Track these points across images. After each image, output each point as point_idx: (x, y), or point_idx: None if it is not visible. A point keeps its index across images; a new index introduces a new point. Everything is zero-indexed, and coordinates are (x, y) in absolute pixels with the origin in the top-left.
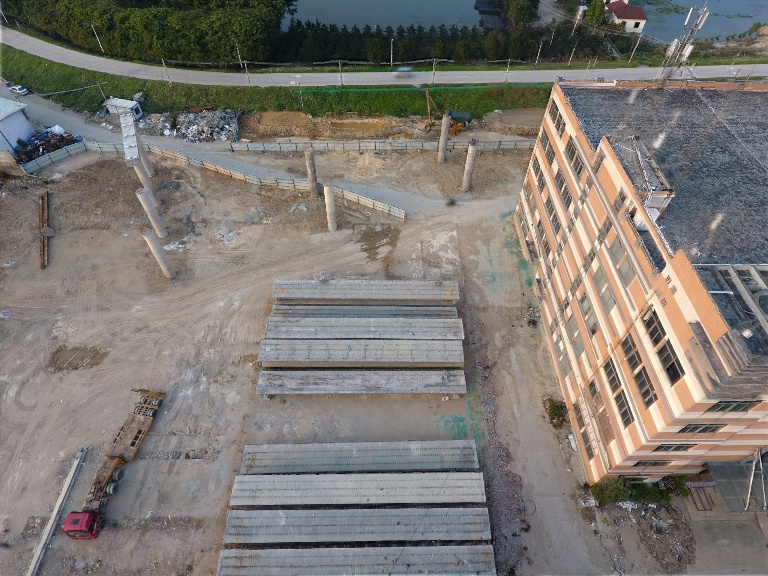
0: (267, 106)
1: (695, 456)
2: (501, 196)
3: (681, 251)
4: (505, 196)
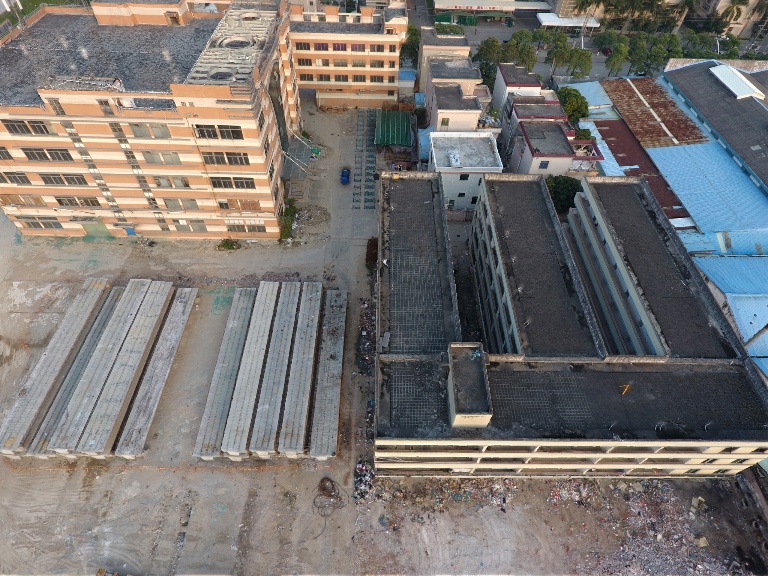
0: None
1: (277, 170)
2: None
3: (172, 85)
4: None
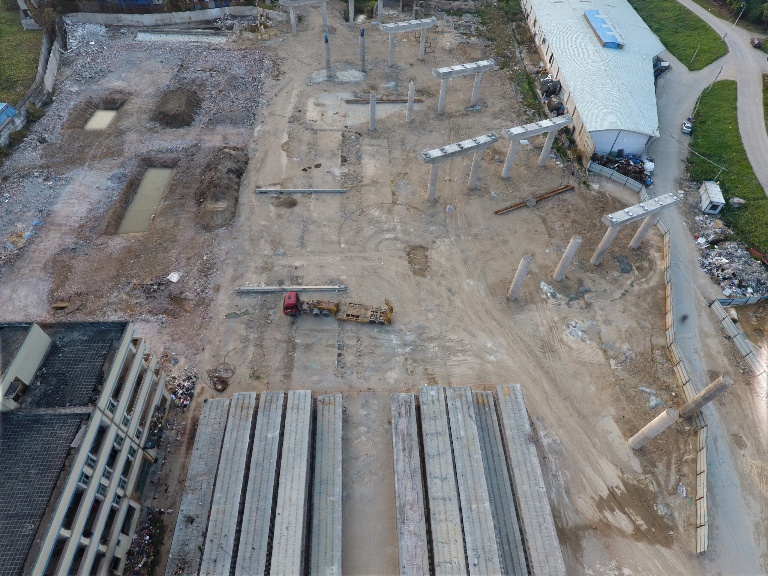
0: None
1: None
2: None
3: None
4: None
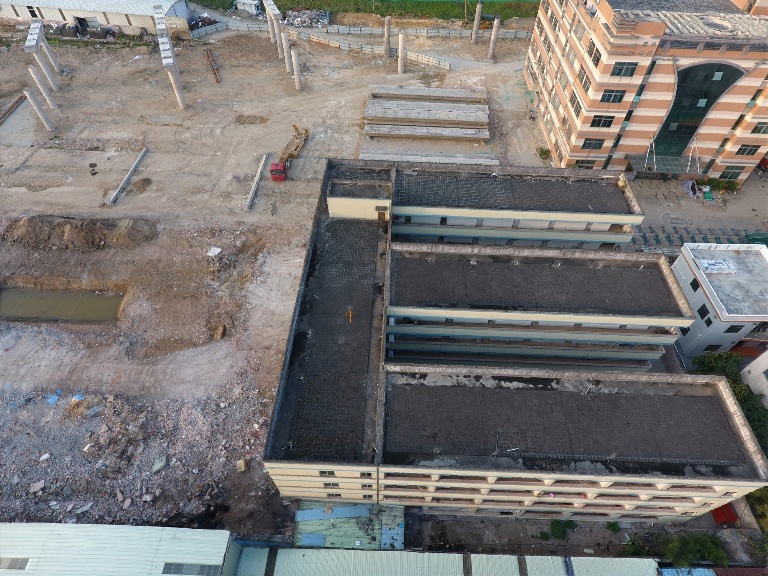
0: (348, 9)
1: (615, 134)
2: (515, 61)
3: None
4: (518, 61)
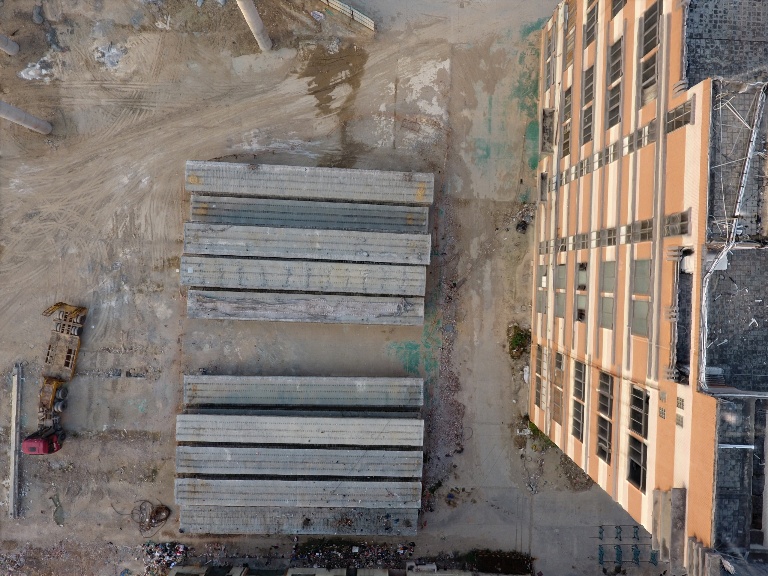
0: None
1: None
2: None
3: (714, 405)
4: None
